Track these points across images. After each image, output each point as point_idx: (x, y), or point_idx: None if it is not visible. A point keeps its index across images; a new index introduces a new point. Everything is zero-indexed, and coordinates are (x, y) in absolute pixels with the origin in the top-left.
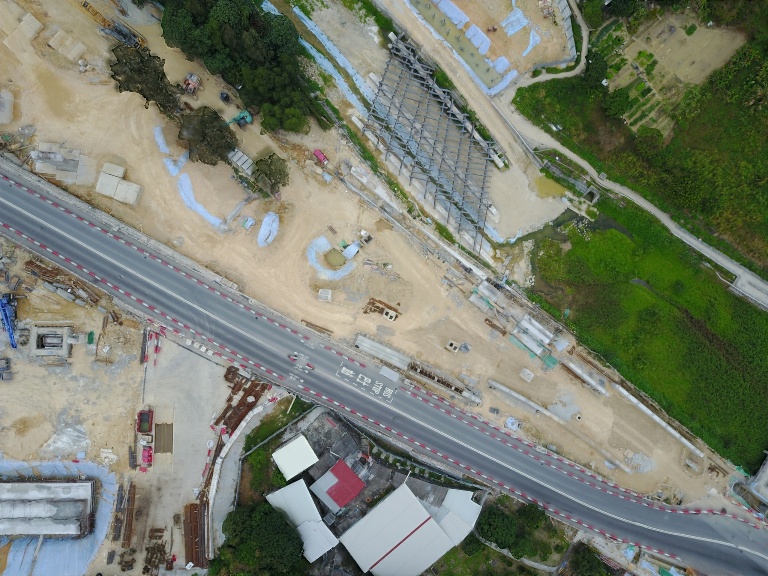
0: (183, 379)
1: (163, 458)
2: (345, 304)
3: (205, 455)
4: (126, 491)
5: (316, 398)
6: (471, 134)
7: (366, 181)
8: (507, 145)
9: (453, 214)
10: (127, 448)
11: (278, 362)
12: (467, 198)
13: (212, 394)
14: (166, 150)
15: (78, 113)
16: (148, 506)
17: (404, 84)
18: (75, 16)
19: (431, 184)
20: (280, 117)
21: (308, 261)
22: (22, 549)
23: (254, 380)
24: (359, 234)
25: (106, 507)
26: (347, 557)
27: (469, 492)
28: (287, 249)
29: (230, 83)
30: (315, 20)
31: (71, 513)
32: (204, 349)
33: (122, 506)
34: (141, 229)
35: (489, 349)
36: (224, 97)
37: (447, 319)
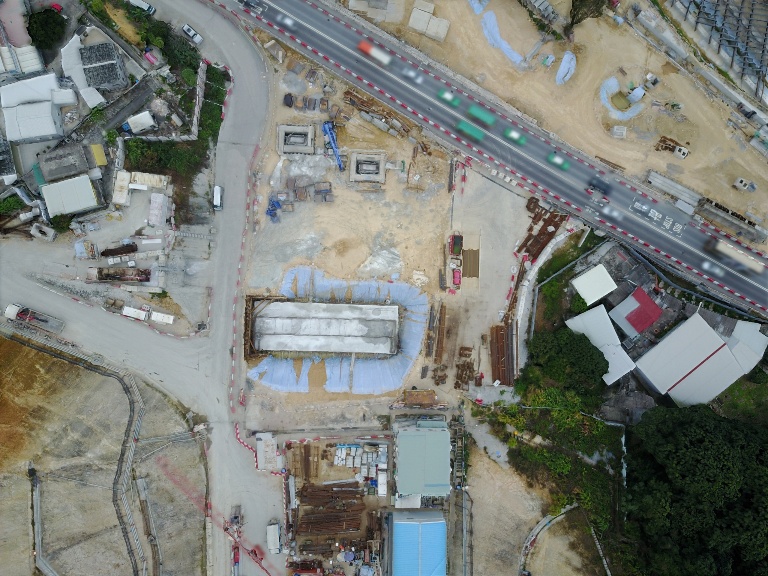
0: (487, 208)
1: (469, 282)
2: (639, 141)
3: (509, 280)
4: (437, 311)
5: (611, 230)
6: None
7: (654, 25)
8: None
9: (734, 60)
10: (438, 271)
11: (575, 195)
12: (749, 45)
13: (514, 223)
14: None
15: None
16: (457, 326)
17: None
18: None
19: (713, 31)
20: None
21: (601, 100)
22: (337, 365)
23: (553, 211)
24: (645, 78)
25: (417, 326)
26: (638, 384)
27: (757, 324)
28: (581, 88)
29: None
30: None
31: (381, 333)
32: (509, 179)
33: (434, 324)
34: (448, 64)
35: None
36: None
37: (732, 160)
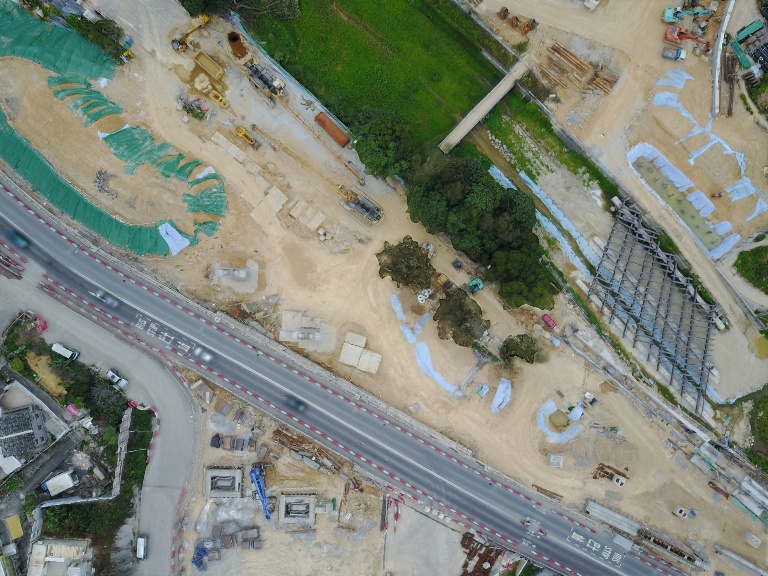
0: (421, 545)
1: None
2: (576, 470)
3: None
4: None
5: (548, 564)
6: (693, 297)
7: (592, 345)
8: (728, 307)
9: (674, 375)
10: None
11: (511, 528)
12: None
13: (449, 560)
14: (403, 318)
15: (319, 282)
16: None
17: (629, 248)
18: (315, 186)
19: (652, 345)
20: (526, 295)
21: (537, 425)
22: None
23: (488, 546)
24: (583, 396)
25: None
26: None
27: None
28: (517, 414)
29: (465, 252)
30: (540, 184)
31: None
32: (442, 516)
33: None
34: (380, 396)
35: (713, 512)
36: (458, 265)
37: (672, 482)
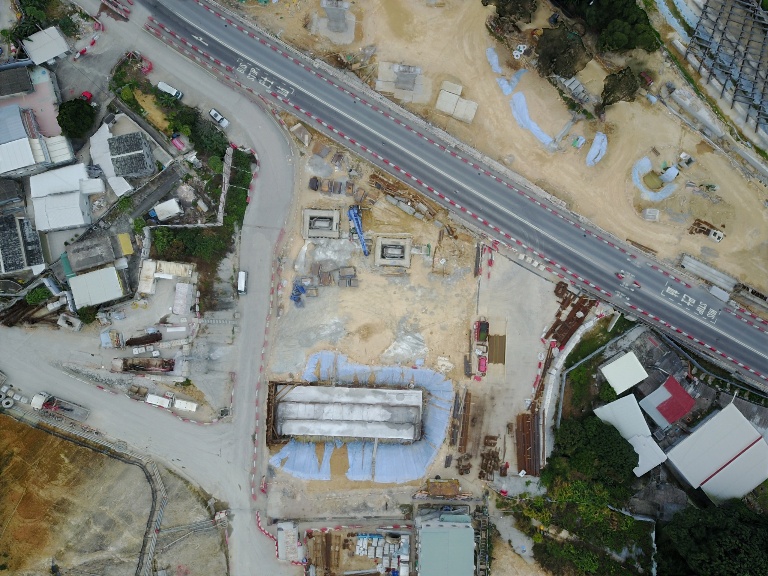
0: (514, 293)
1: (495, 368)
2: (672, 224)
3: (535, 367)
4: (462, 398)
5: (642, 316)
6: None
7: (689, 103)
8: None
9: None
10: (463, 357)
11: (605, 279)
12: None
13: (542, 308)
14: (498, 70)
15: (415, 33)
16: (482, 414)
17: (729, 6)
18: None
19: (751, 108)
20: (628, 33)
21: (632, 181)
22: (360, 450)
23: (582, 296)
24: (678, 157)
25: (441, 413)
26: (669, 474)
27: None
28: (612, 169)
29: (562, 4)
30: None
31: (404, 419)
32: (536, 264)
33: (459, 412)
34: (475, 146)
35: None
36: (555, 18)
37: None
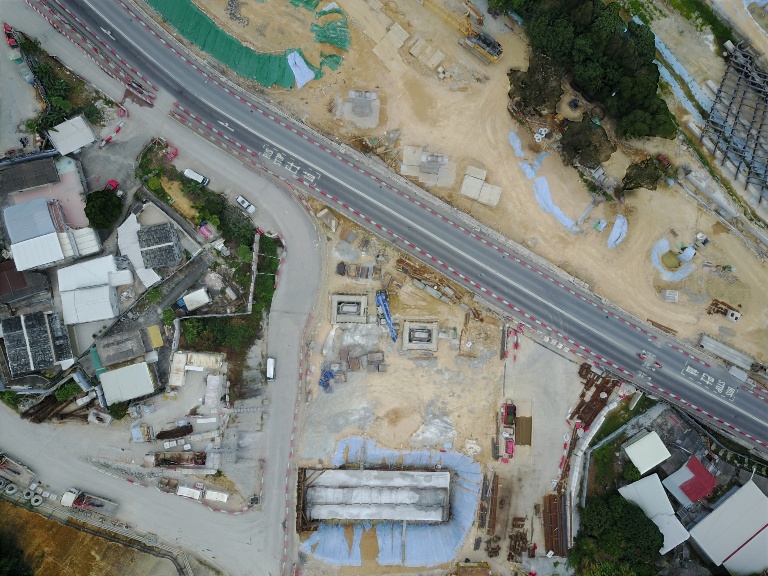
0: (540, 374)
1: (522, 450)
2: (691, 305)
3: (561, 448)
4: (490, 481)
5: (664, 395)
6: None
7: (705, 185)
8: None
9: None
10: (490, 439)
11: (627, 360)
12: None
13: (566, 389)
14: (521, 154)
15: (439, 118)
16: (510, 495)
17: (742, 91)
18: (434, 25)
19: (763, 189)
20: (649, 123)
21: (652, 262)
22: (388, 533)
23: (605, 377)
24: (695, 237)
25: (469, 495)
26: (692, 550)
27: None
28: (632, 251)
29: (583, 90)
30: (653, 29)
31: (432, 500)
32: (561, 346)
33: (487, 495)
34: (500, 230)
35: None
36: (575, 103)
37: None
